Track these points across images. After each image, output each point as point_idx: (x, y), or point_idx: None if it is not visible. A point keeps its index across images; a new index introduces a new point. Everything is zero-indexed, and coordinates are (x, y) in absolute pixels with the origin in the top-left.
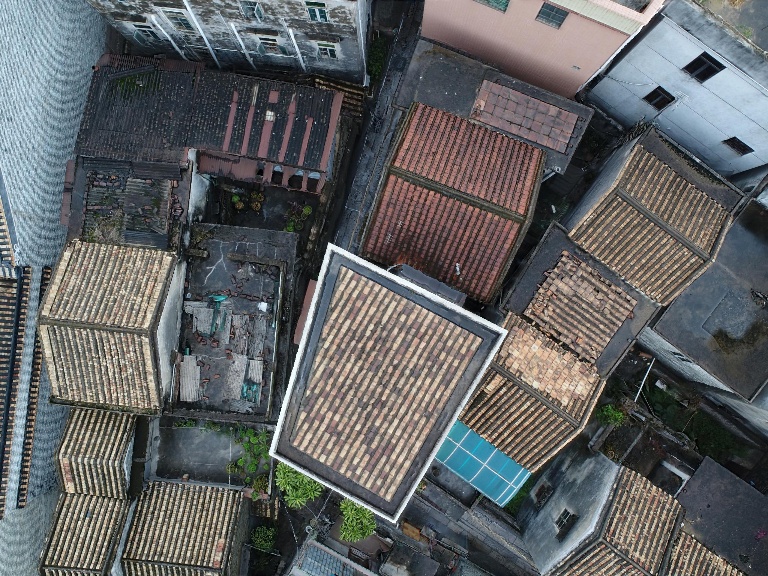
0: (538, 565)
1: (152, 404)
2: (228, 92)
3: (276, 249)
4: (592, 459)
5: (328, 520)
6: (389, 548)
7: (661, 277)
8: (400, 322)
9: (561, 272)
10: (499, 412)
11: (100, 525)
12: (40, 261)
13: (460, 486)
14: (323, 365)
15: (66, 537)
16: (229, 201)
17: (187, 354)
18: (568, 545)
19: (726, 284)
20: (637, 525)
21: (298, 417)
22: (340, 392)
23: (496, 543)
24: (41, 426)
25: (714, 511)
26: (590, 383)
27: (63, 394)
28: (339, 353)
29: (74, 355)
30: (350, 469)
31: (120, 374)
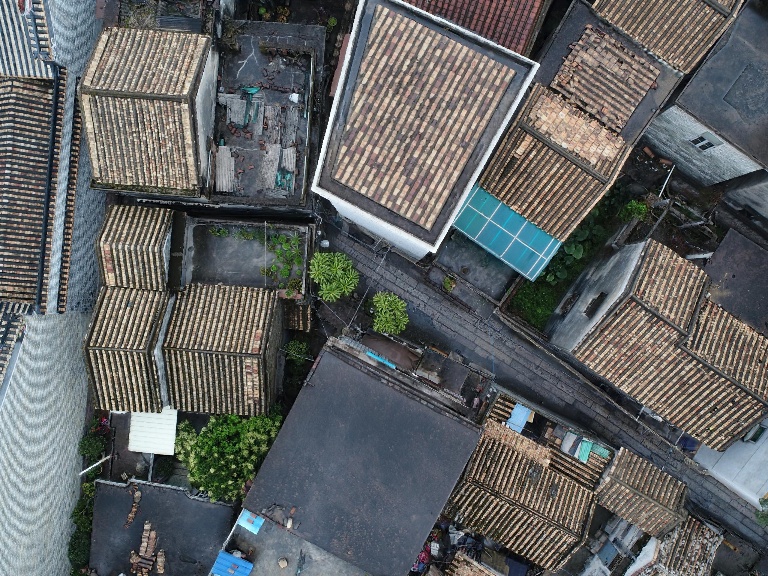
0: (568, 346)
1: (190, 184)
2: None
3: (306, 42)
4: (617, 253)
5: (360, 329)
6: (419, 358)
7: (683, 42)
8: (435, 57)
9: (585, 44)
10: (529, 179)
11: (141, 313)
12: (74, 69)
13: (489, 285)
14: (362, 100)
15: (109, 323)
16: (256, 12)
17: (222, 145)
18: (598, 316)
19: (746, 57)
20: (666, 287)
21: (339, 151)
22: (379, 126)
23: (522, 366)
24: (77, 240)
25: (739, 281)
26: (617, 148)
27: (103, 177)
28: (377, 88)
29: (115, 131)
30: (391, 200)
31: (159, 150)
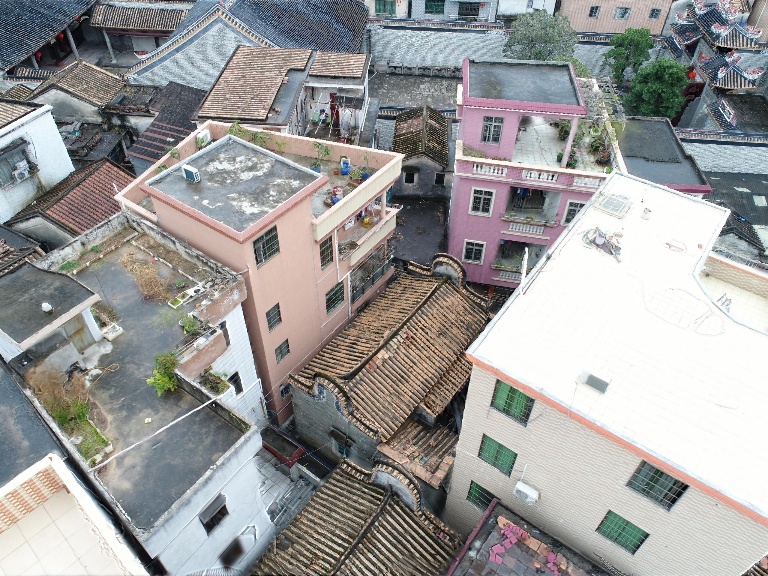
0: None
1: None
2: (191, 129)
3: (97, 153)
4: None
5: None
6: None
7: None
8: None
9: None
10: None
11: None
12: None
13: None
14: None
15: None
16: None
17: None
18: None
19: None
20: None
21: None
22: None
23: None
24: None
25: None
26: None
27: None
28: None
29: None
30: None
31: None
